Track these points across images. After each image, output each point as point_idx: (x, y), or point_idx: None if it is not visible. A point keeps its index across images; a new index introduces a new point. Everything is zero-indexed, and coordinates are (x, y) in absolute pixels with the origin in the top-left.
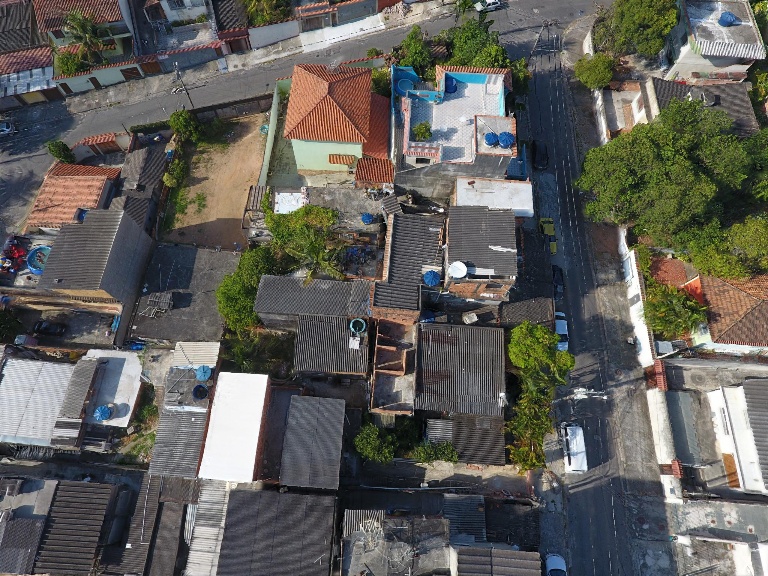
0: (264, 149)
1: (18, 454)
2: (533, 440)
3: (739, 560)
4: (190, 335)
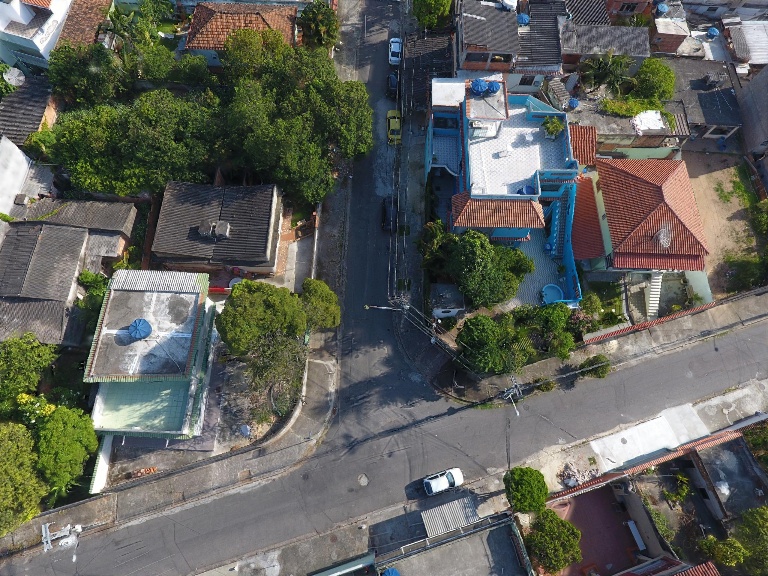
0: None
1: None
2: None
3: None
4: (679, 63)
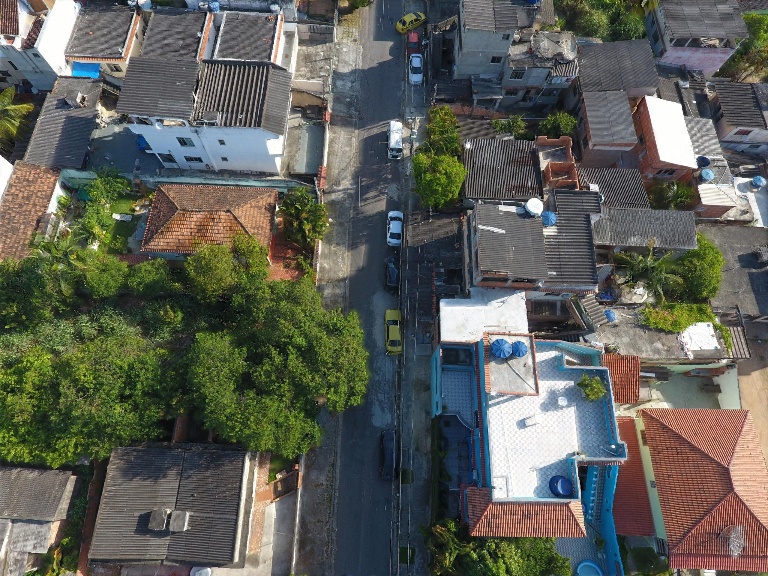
0: None
1: None
2: None
3: None
4: (724, 231)
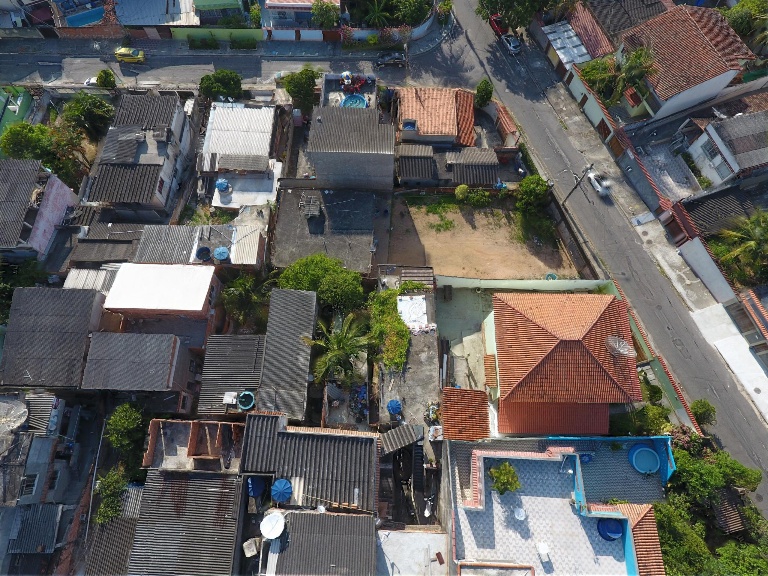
0: None
1: (202, 136)
2: None
3: None
4: (281, 239)
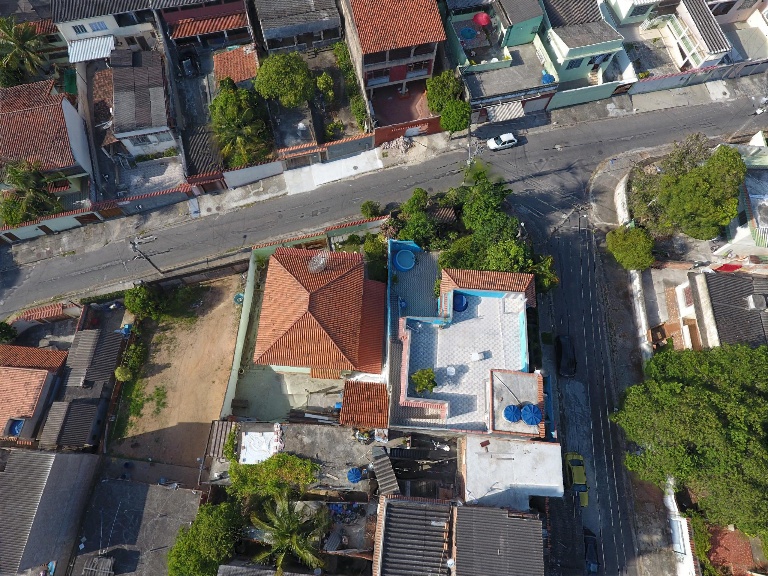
0: (238, 325)
1: None
2: None
3: None
4: None
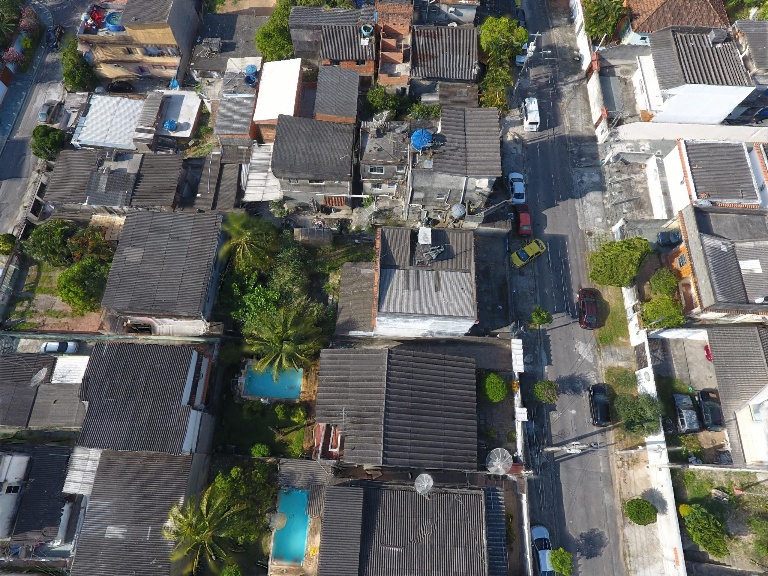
0: None
1: None
2: (498, 89)
3: (649, 171)
4: None
